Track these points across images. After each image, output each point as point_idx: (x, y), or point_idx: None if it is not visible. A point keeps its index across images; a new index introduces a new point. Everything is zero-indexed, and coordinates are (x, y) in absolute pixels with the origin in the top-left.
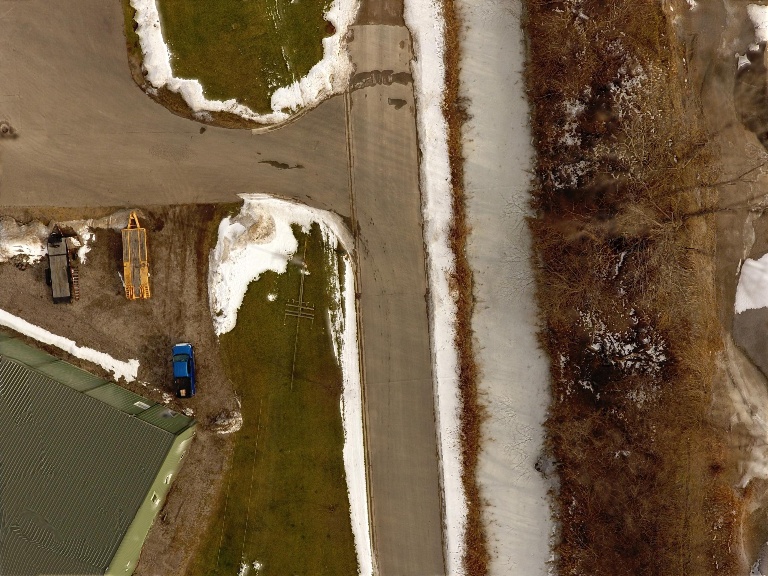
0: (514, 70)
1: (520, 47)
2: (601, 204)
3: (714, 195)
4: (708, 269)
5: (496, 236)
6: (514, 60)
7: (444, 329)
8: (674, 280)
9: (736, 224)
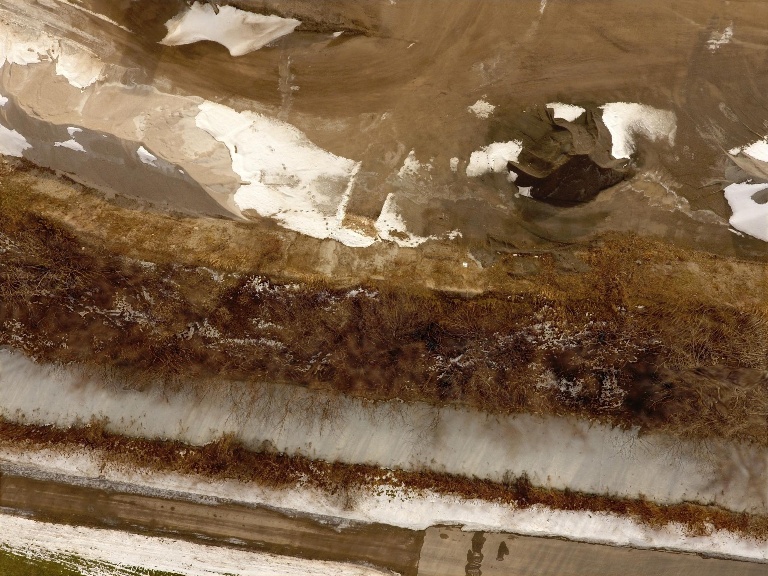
0: (484, 421)
1: (462, 411)
2: (665, 385)
3: (658, 247)
4: (739, 272)
5: (651, 471)
6: (475, 420)
7: (743, 547)
8: (765, 332)
9: (691, 228)
